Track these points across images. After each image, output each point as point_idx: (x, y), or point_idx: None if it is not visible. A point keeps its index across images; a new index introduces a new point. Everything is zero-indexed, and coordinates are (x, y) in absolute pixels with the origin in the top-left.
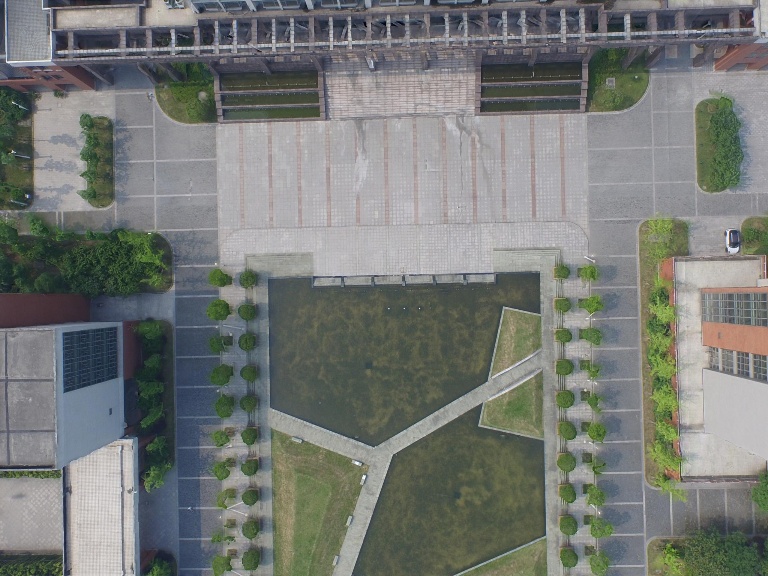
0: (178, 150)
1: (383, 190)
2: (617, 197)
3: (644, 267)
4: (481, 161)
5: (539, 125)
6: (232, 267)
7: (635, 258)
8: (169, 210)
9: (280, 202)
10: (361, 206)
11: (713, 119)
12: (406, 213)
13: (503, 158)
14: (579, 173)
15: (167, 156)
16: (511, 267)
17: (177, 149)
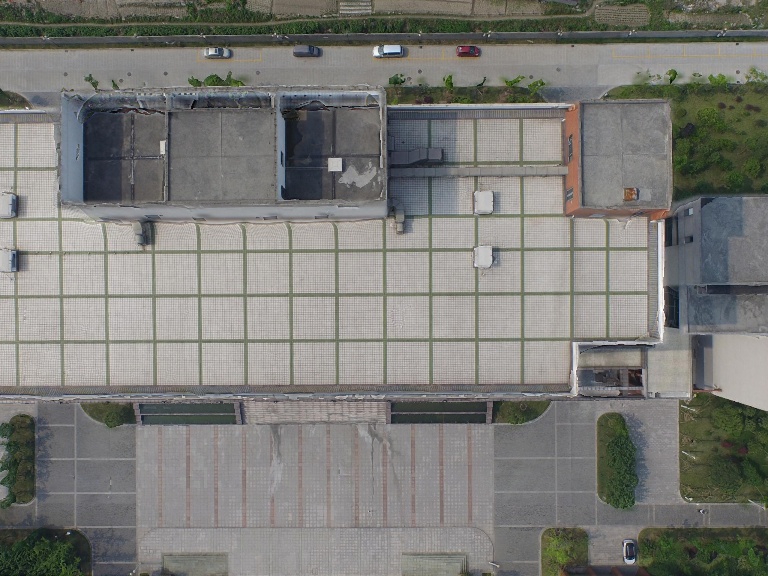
0: (98, 449)
1: (297, 493)
2: (521, 505)
3: (546, 574)
4: (392, 467)
5: (448, 434)
6: (149, 565)
7: (537, 564)
8: (89, 507)
9: (197, 502)
10: (275, 508)
11: (610, 446)
12: (319, 516)
13: (413, 465)
14: (485, 481)
15: (88, 455)
16: (418, 572)
17: (97, 448)
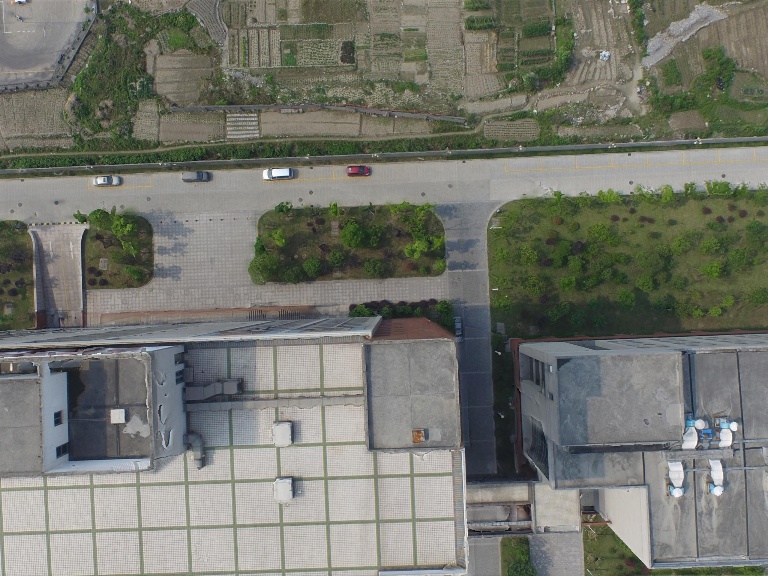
0: None
1: None
2: None
3: None
4: None
5: None
6: None
7: None
8: None
9: None
10: None
11: (509, 571)
12: None
13: None
14: None
15: None
16: None
17: None
